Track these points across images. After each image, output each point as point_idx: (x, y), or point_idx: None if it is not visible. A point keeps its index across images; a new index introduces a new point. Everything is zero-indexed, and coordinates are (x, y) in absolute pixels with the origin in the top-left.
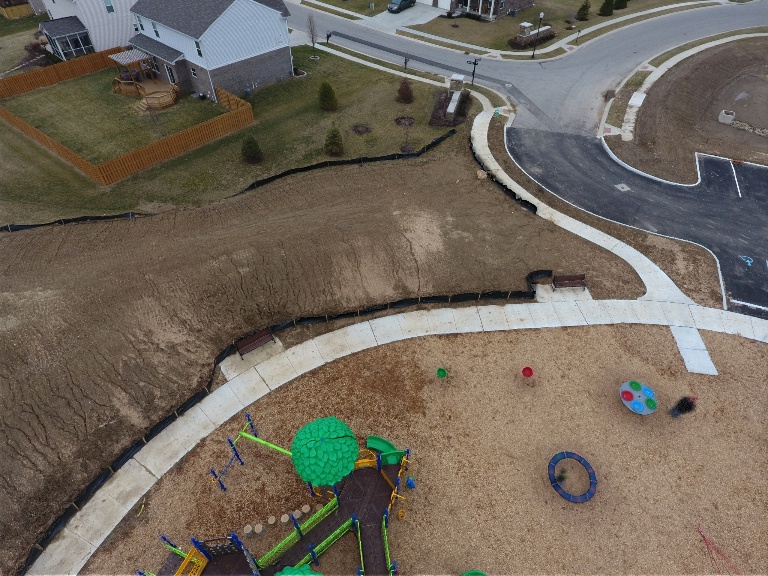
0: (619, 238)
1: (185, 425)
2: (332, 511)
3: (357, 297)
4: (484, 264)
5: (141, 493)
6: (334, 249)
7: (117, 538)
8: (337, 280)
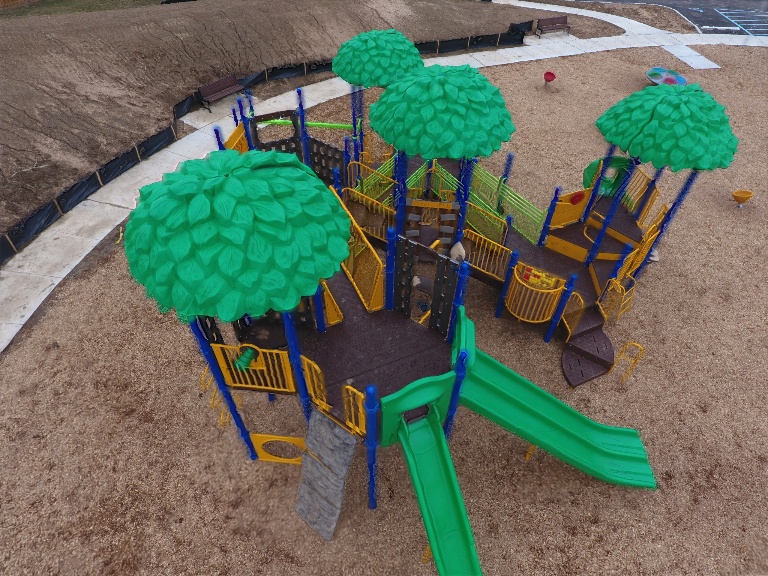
0: (579, 7)
1: (154, 166)
2: (392, 185)
3: (333, 54)
4: (461, 24)
5: (113, 224)
6: (290, 16)
7: (92, 265)
8: (304, 41)
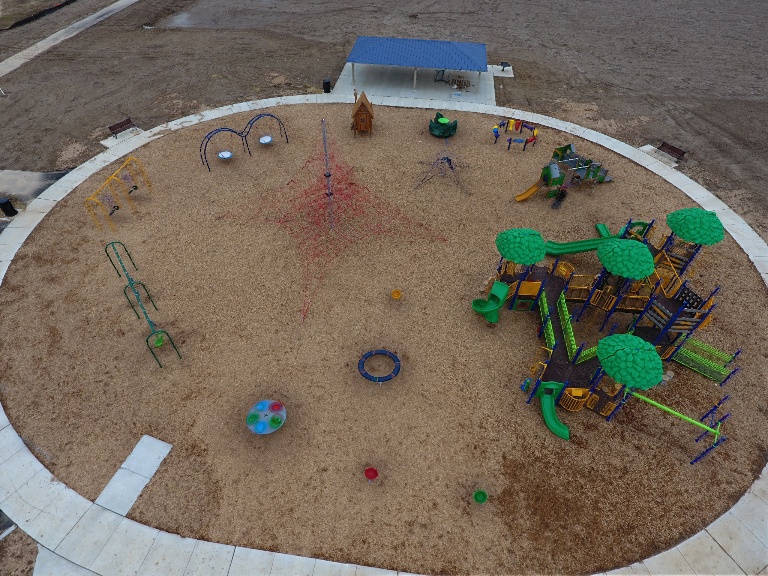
0: None
1: None
2: None
3: None
4: None
5: None
6: None
7: None
8: None
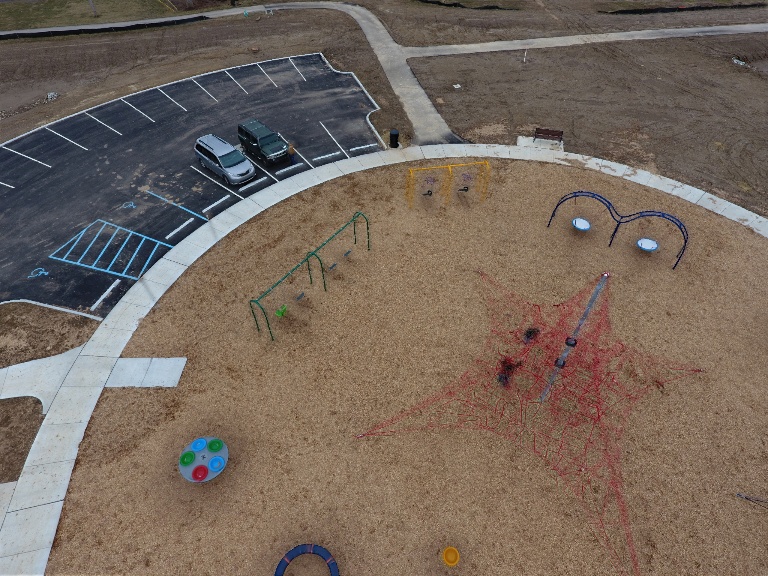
0: None
1: None
2: None
3: None
4: None
5: None
6: None
7: None
8: None
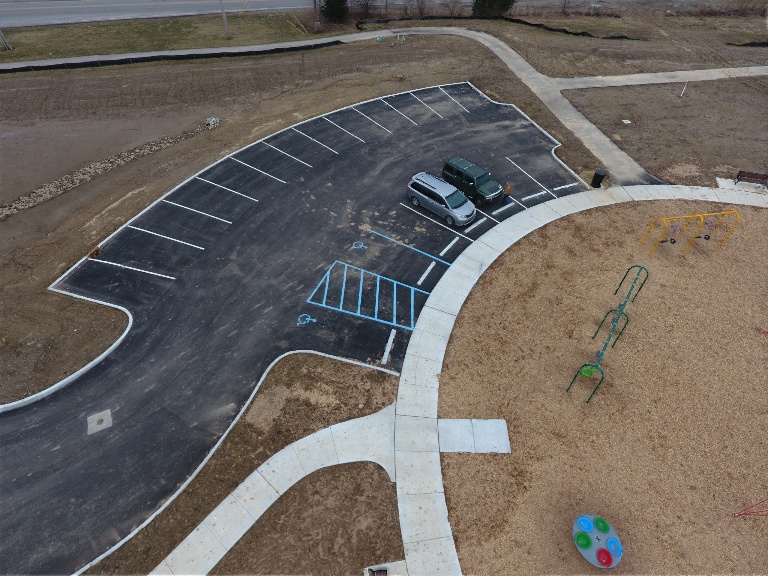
0: (249, 470)
1: None
2: None
3: None
4: None
5: None
6: None
7: None
8: None
